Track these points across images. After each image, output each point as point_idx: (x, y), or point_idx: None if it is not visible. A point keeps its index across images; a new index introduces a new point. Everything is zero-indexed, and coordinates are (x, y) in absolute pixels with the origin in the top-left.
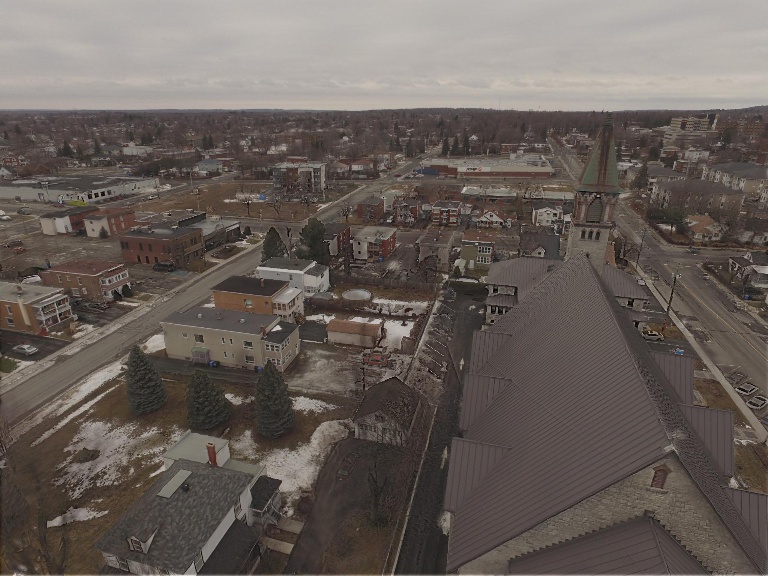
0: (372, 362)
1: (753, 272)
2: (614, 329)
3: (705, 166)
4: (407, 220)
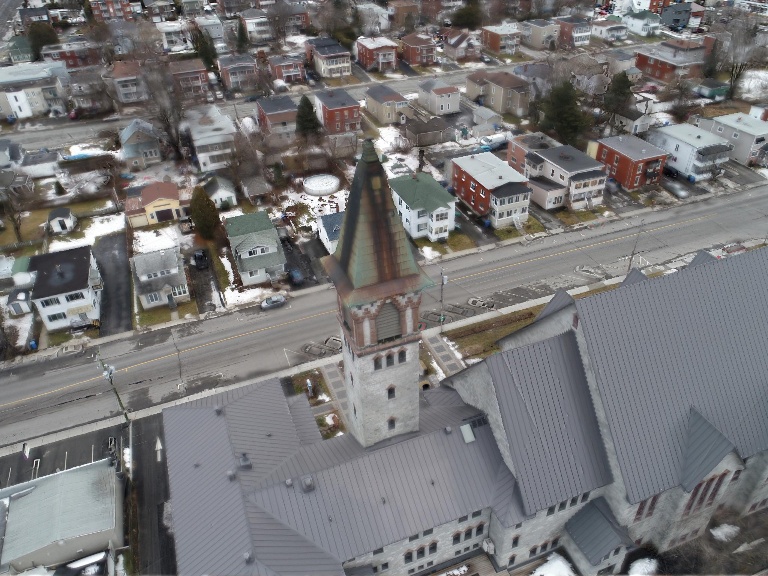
0: None
1: None
2: None
3: None
4: None
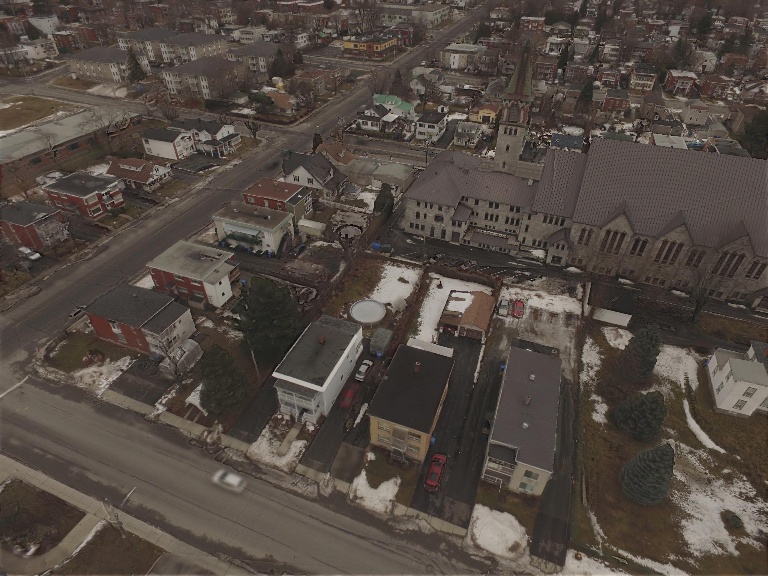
0: (523, 310)
1: (383, 123)
2: (721, 156)
3: (120, 38)
4: (63, 237)
